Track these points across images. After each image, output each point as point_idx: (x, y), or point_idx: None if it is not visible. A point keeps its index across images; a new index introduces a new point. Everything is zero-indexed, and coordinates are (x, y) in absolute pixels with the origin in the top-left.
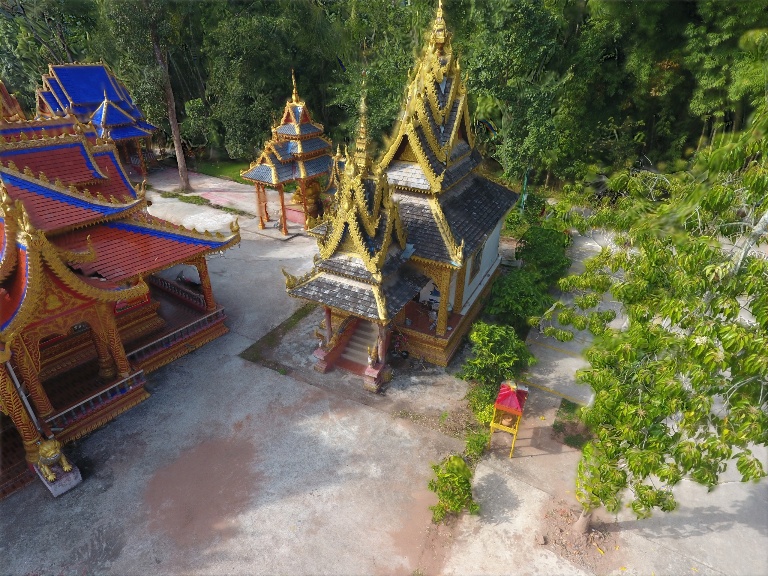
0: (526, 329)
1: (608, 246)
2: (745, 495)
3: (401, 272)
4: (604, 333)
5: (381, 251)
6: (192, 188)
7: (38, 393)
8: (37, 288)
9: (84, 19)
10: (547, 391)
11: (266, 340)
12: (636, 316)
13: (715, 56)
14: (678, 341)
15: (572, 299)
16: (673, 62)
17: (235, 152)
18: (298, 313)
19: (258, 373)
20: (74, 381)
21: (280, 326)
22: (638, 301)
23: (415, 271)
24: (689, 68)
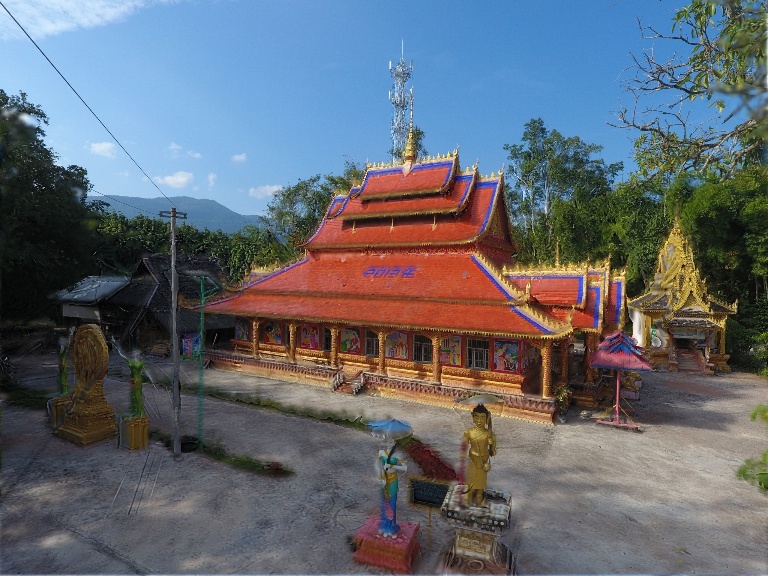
0: None
1: None
2: None
3: None
4: None
5: None
6: None
7: None
8: None
9: None
10: None
11: None
12: None
13: (763, 246)
14: None
15: None
16: (735, 252)
17: None
18: None
19: None
20: None
21: None
22: None
23: None
24: (749, 253)
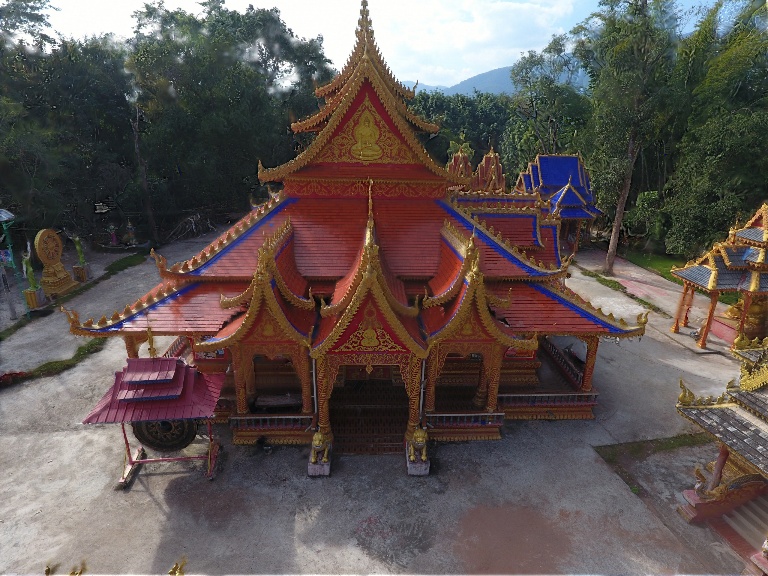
0: None
1: None
2: None
3: None
4: None
5: None
6: (613, 272)
7: (431, 392)
8: (462, 315)
9: (578, 120)
10: None
11: (630, 447)
12: None
13: None
14: None
15: None
16: None
17: (674, 247)
18: (682, 438)
19: (607, 476)
20: (455, 396)
21: (653, 441)
22: None
23: None
24: None
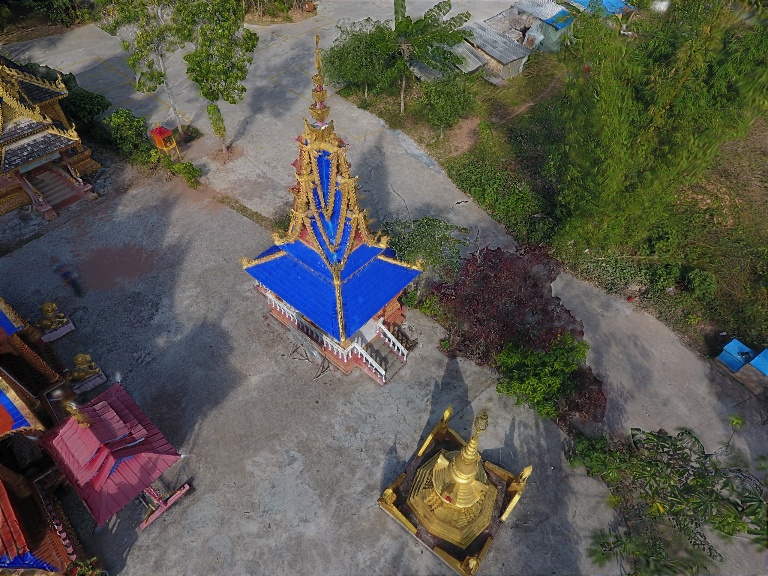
0: (101, 126)
1: (137, 32)
2: (240, 112)
3: None
4: (158, 80)
5: (32, 105)
6: None
7: None
8: None
9: None
10: (152, 138)
11: None
12: (203, 35)
13: None
14: (217, 35)
15: (141, 68)
16: None
17: None
18: None
19: (27, 249)
20: None
21: None
22: (192, 34)
23: None
24: None
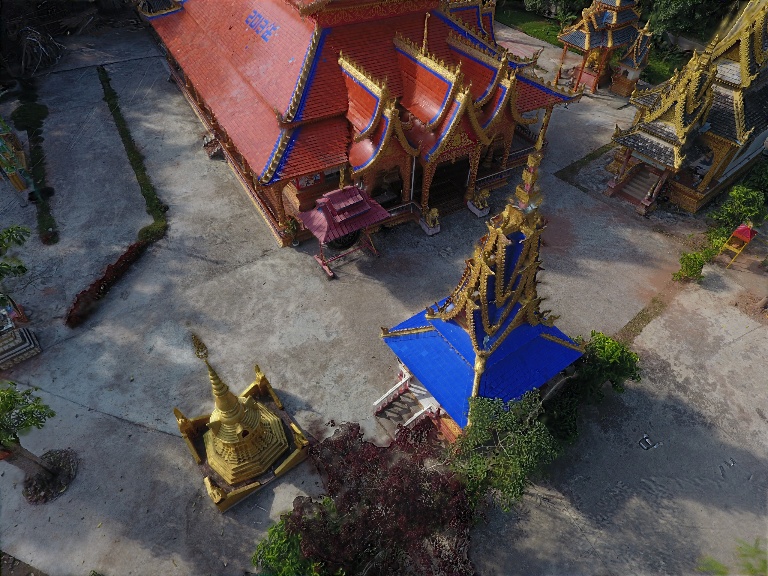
0: (766, 204)
1: None
2: None
3: (695, 141)
4: None
5: (691, 124)
6: None
7: None
8: (502, 110)
9: None
10: (766, 244)
11: (569, 169)
12: None
13: None
14: None
15: None
16: None
17: (533, 5)
18: (589, 156)
19: (567, 187)
20: None
21: (577, 162)
22: None
23: (703, 142)
24: None
